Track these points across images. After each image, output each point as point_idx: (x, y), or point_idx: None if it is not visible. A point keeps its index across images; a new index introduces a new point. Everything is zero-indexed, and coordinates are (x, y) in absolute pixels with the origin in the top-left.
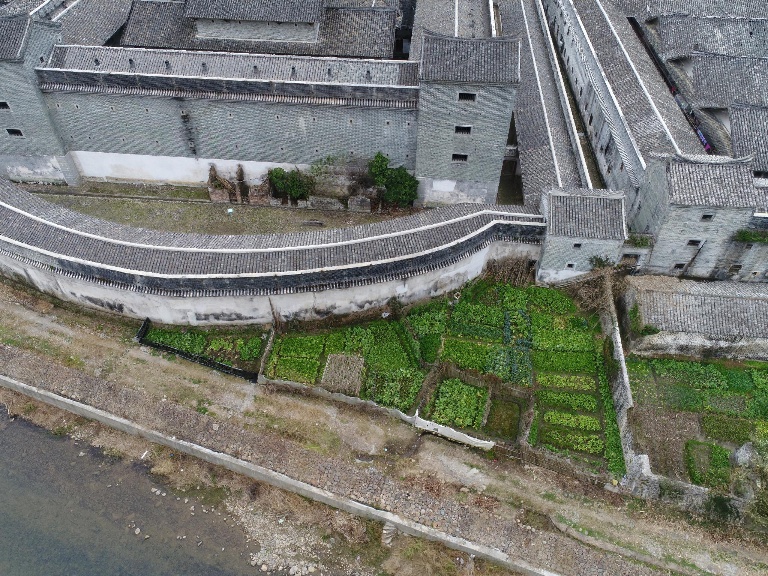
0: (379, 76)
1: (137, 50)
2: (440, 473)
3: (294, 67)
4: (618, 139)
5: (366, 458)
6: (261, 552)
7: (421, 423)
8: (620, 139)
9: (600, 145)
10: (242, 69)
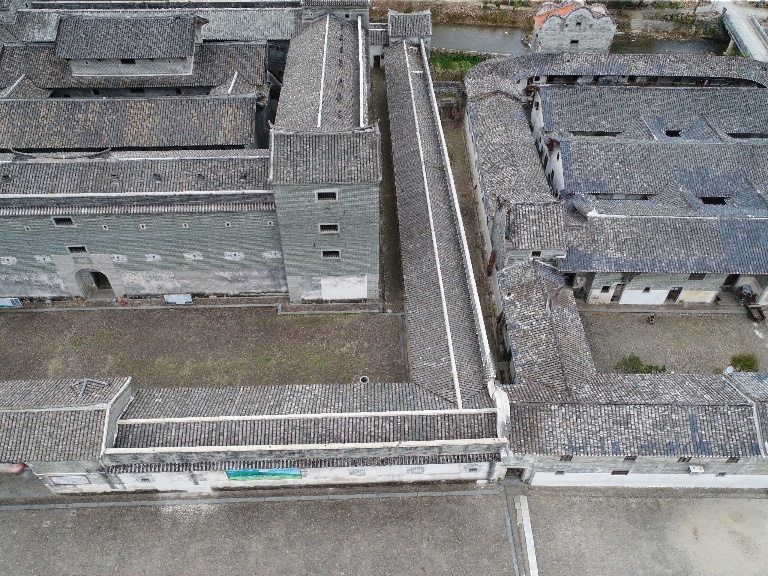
0: None
1: (238, 9)
2: None
3: None
4: None
5: None
6: None
7: None
8: None
9: None
10: None
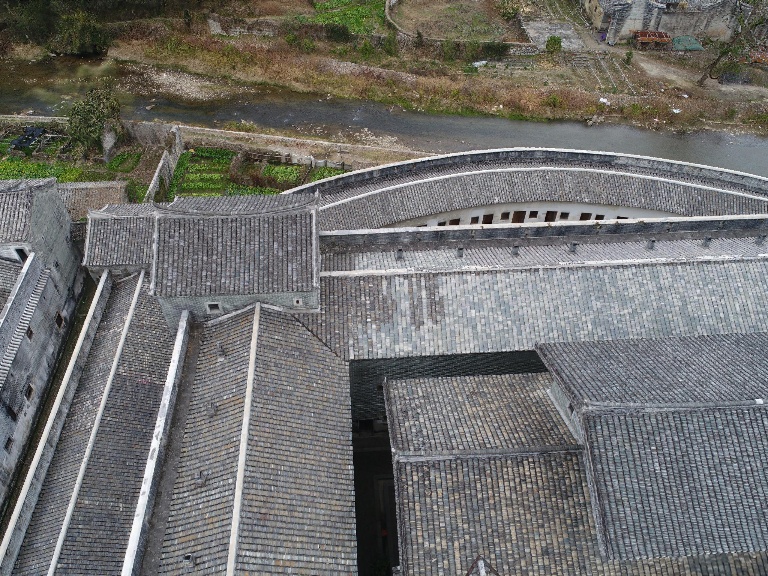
0: (385, 262)
1: None
2: (296, 148)
3: (515, 243)
4: (8, 356)
5: (343, 153)
6: (393, 141)
7: (309, 161)
8: (7, 351)
9: (5, 454)
10: (598, 254)
